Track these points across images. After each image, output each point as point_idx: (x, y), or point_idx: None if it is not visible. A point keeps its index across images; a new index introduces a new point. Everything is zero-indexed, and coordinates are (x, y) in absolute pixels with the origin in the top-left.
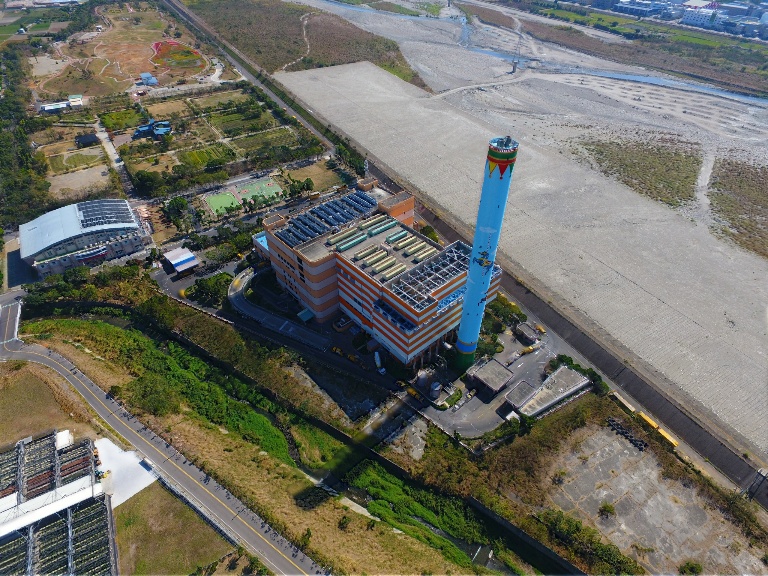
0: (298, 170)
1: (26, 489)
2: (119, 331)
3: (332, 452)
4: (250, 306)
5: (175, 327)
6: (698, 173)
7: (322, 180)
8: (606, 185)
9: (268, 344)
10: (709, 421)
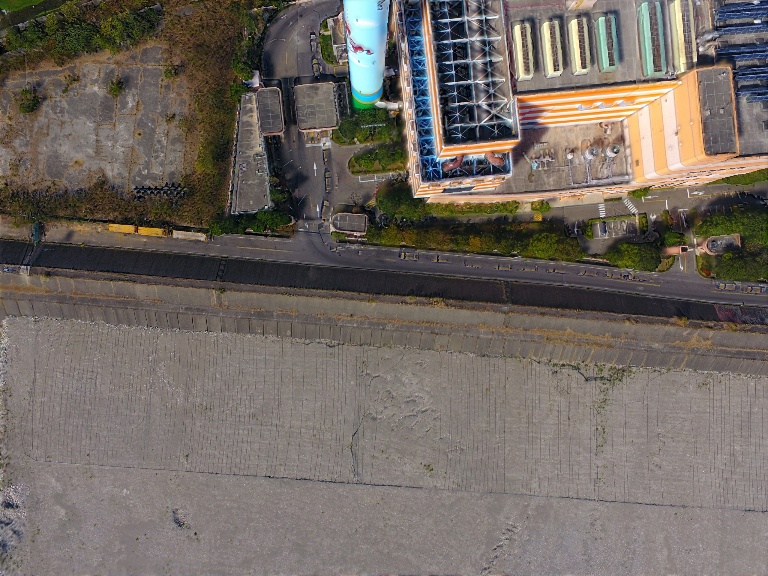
0: None
1: None
2: None
3: None
4: None
5: None
6: None
7: None
8: None
9: None
10: (103, 295)
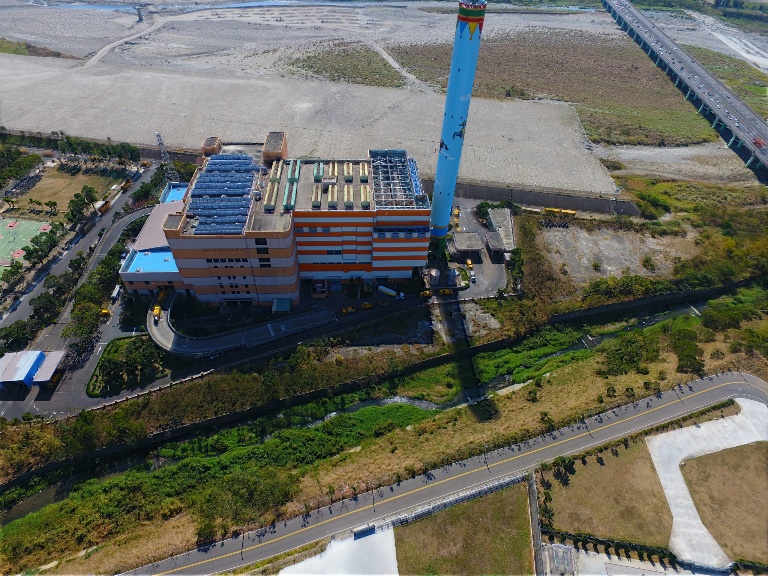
0: (30, 193)
1: None
2: (60, 506)
3: (448, 376)
4: (210, 341)
5: (145, 431)
6: (386, 60)
7: None
8: (348, 88)
9: (281, 355)
10: (569, 192)
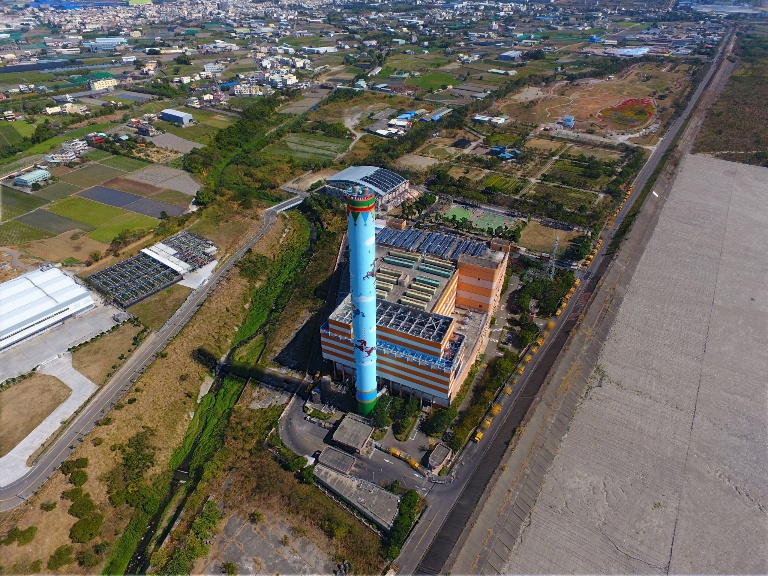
0: (546, 227)
1: (183, 255)
2: (304, 237)
3: (246, 360)
4: None
5: (317, 252)
6: None
7: (547, 244)
8: None
9: (323, 293)
10: None
